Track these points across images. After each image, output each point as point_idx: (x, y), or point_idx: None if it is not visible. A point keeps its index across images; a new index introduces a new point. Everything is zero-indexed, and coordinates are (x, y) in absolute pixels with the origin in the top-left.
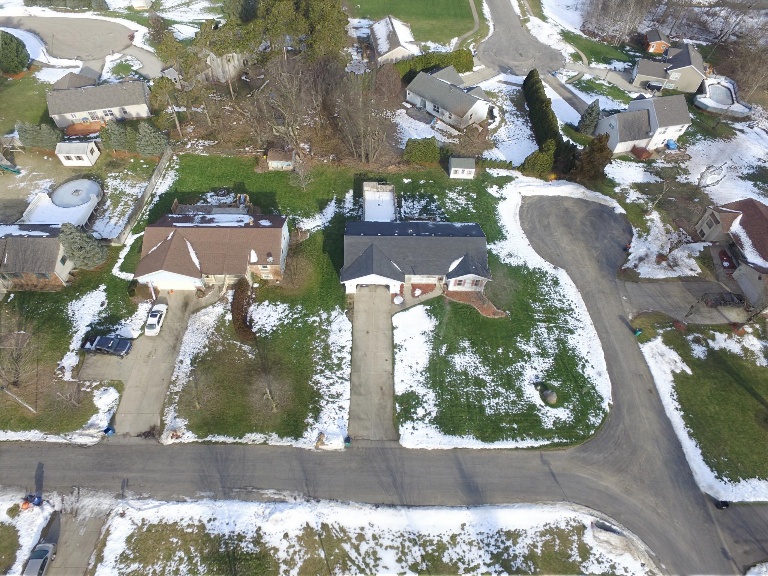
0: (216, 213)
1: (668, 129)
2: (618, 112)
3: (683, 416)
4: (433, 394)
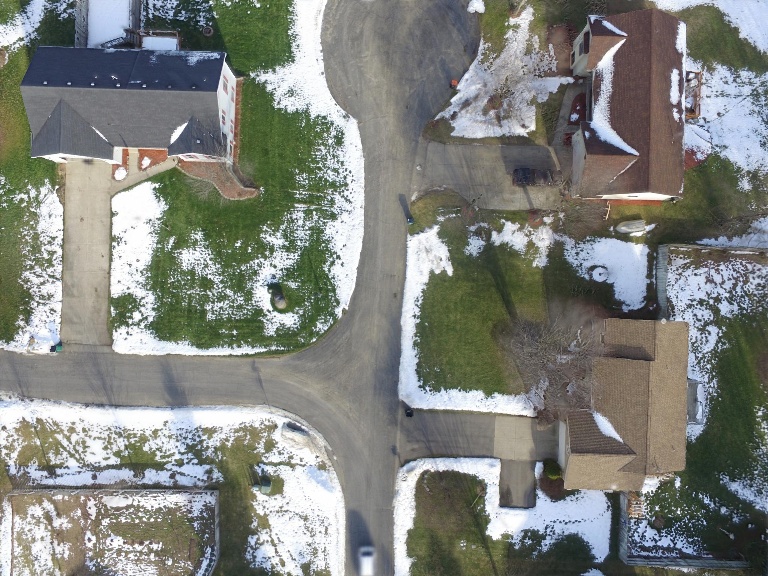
0: None
1: None
2: None
3: (417, 324)
4: (152, 297)
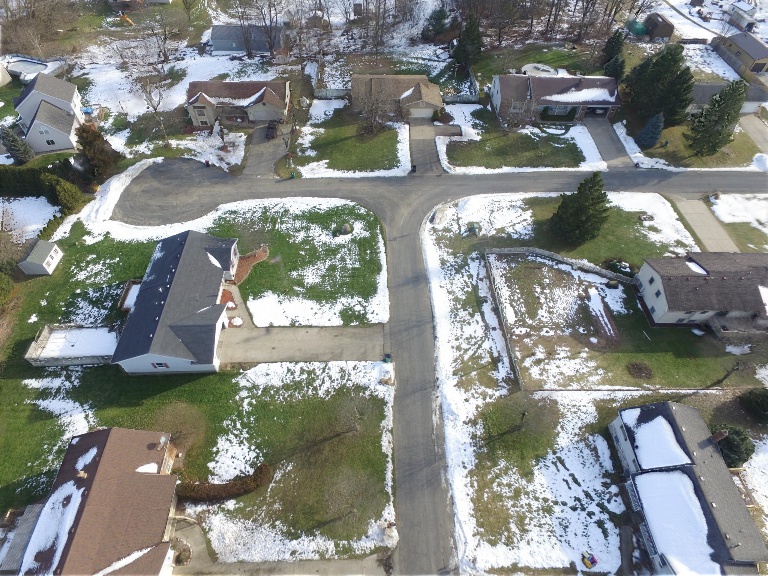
0: (20, 559)
1: (74, 100)
2: None
3: (359, 171)
4: (342, 299)
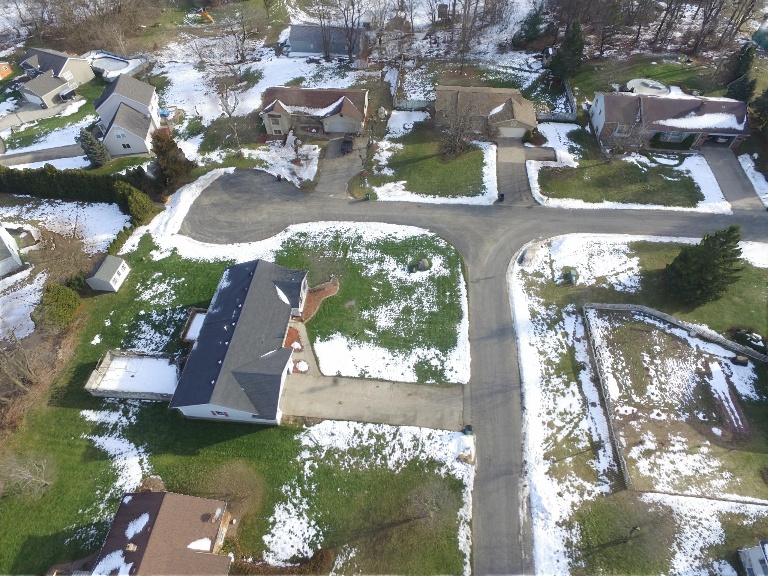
0: None
1: (151, 103)
2: (89, 130)
3: (440, 196)
4: (417, 349)
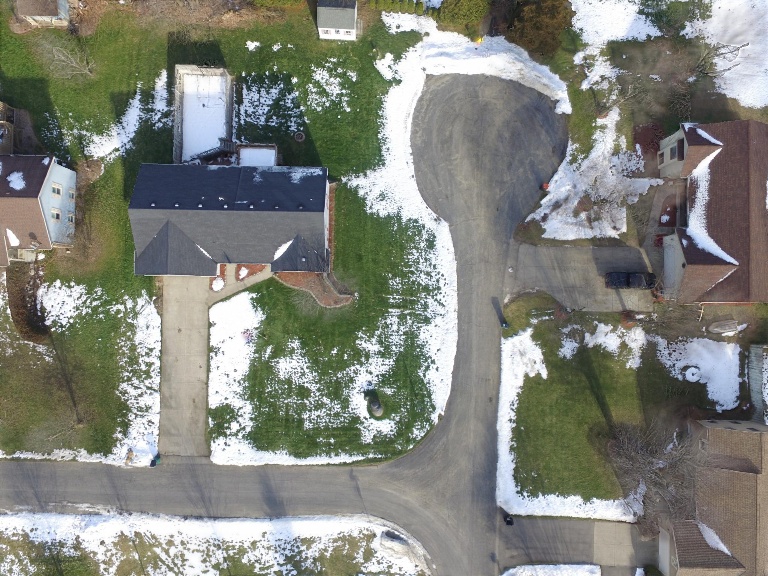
0: None
1: None
2: None
3: (513, 429)
4: (250, 407)
